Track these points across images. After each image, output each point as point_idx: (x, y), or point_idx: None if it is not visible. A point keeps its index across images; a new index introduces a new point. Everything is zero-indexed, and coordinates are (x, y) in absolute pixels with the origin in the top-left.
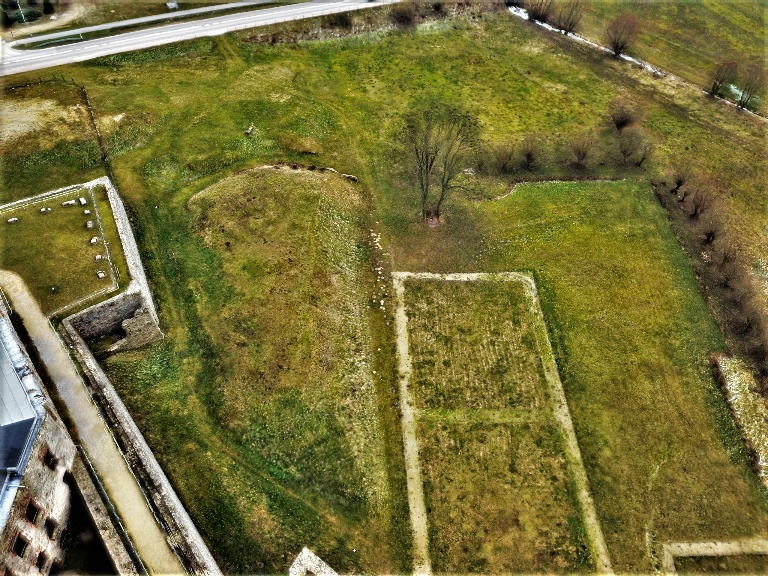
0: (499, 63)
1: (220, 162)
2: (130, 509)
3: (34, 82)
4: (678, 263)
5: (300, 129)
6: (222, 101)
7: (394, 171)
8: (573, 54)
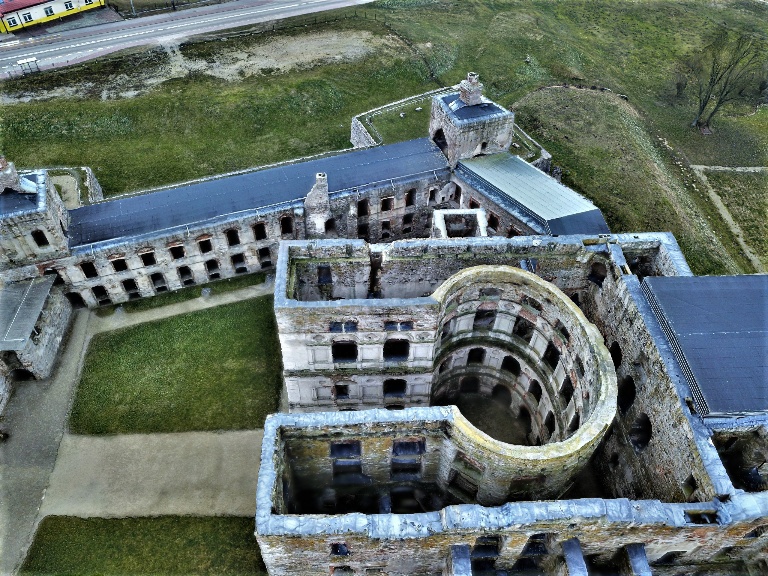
0: (696, 15)
1: (516, 82)
2: None
3: (340, 18)
4: None
5: (564, 60)
6: (491, 38)
7: (651, 95)
8: (754, 10)
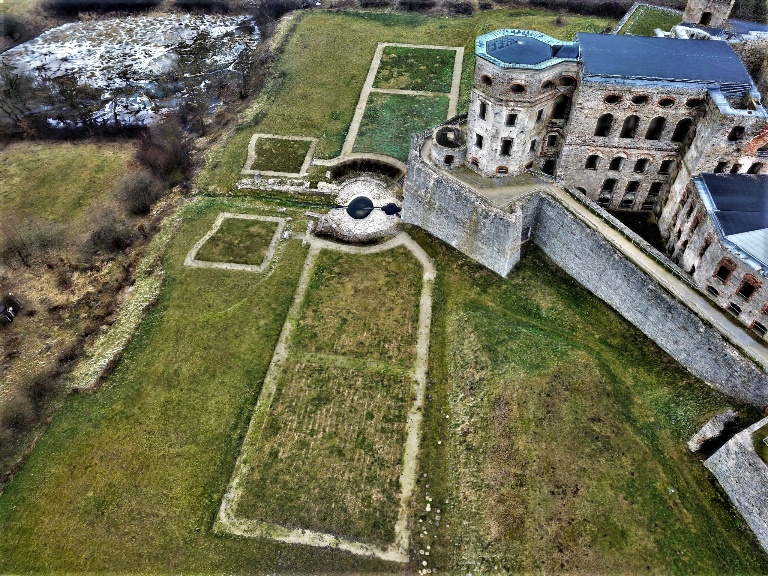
0: None
1: None
2: (636, 253)
3: None
4: (1, 520)
5: None
6: None
7: None
8: None
